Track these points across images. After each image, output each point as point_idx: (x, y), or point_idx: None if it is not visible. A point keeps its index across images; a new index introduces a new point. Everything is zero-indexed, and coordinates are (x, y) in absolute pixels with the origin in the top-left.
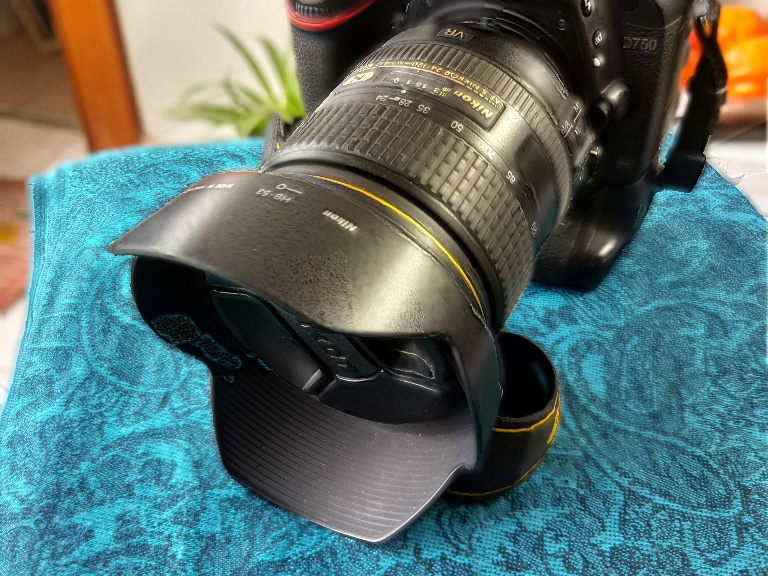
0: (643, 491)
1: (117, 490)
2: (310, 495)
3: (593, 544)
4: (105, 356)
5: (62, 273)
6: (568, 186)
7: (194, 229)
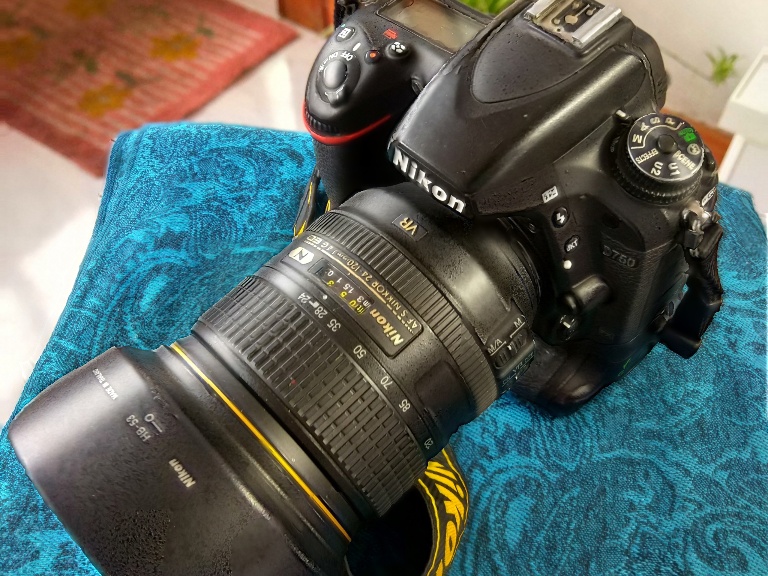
0: None
1: None
2: None
3: None
4: None
5: (101, 264)
6: (495, 389)
7: (61, 450)
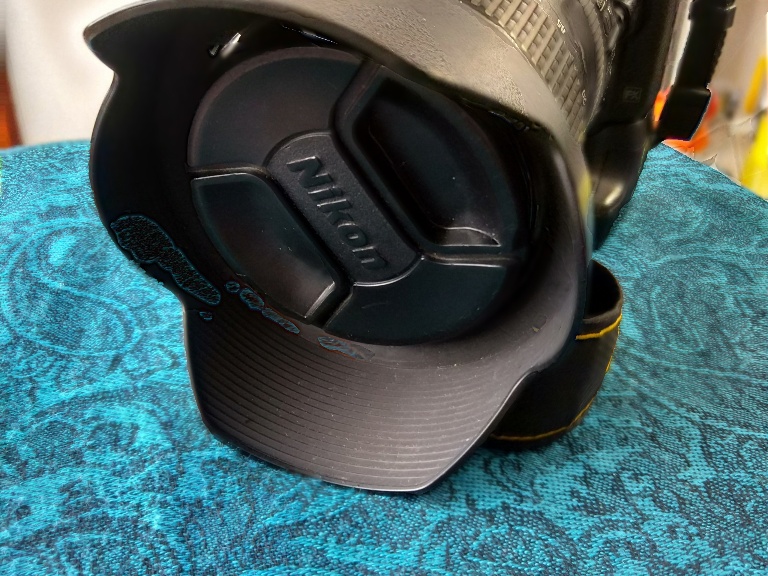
0: (720, 424)
1: (59, 459)
2: (320, 451)
3: (682, 480)
4: (32, 321)
5: None
6: (602, 74)
7: None
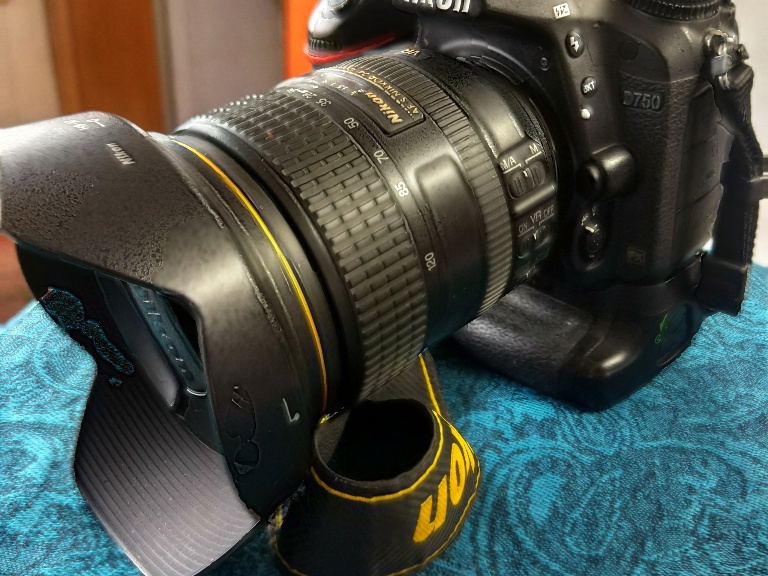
0: None
1: None
2: (141, 527)
3: None
4: (51, 351)
5: None
6: (509, 236)
7: None
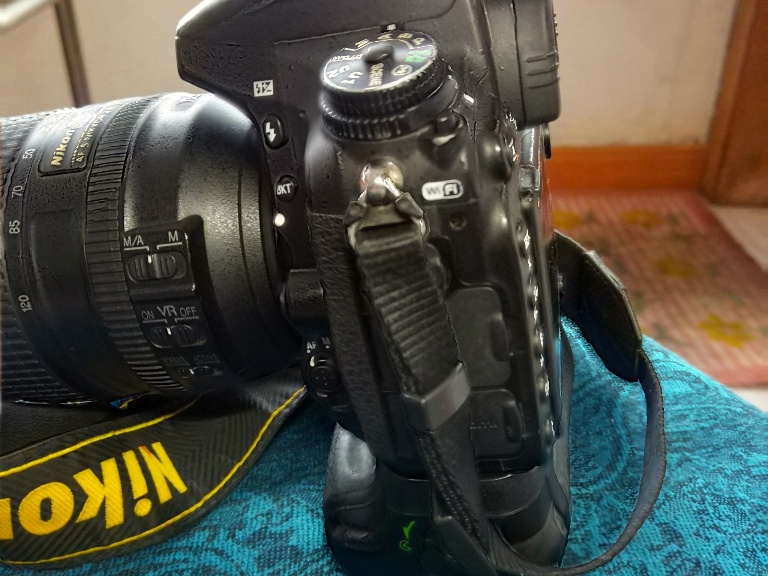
0: None
1: None
2: None
3: None
4: None
5: None
6: (133, 317)
7: None
